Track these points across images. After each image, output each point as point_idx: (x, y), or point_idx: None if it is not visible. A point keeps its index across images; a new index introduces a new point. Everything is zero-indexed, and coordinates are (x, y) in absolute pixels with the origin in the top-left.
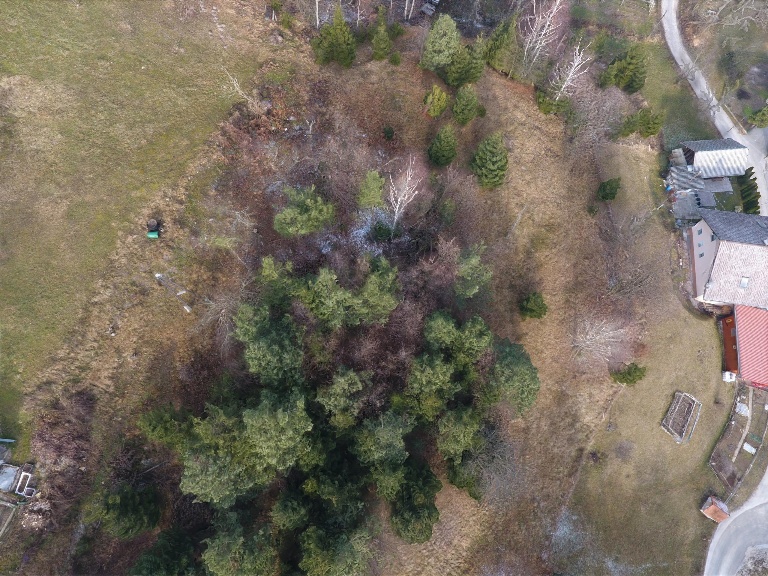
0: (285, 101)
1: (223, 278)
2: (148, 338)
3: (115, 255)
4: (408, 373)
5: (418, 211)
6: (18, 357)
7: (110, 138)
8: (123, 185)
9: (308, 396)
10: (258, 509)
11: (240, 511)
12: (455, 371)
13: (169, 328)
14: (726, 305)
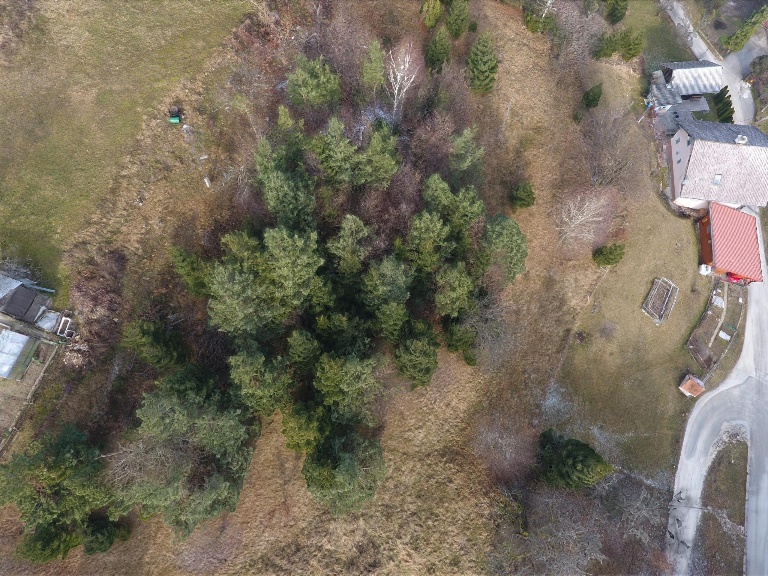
0: (292, 13)
1: (239, 158)
2: (172, 209)
3: (141, 136)
4: (408, 231)
5: (416, 115)
6: (56, 219)
7: (133, 37)
8: (146, 77)
9: (319, 247)
10: (275, 349)
11: (260, 346)
12: (451, 237)
13: (191, 200)
14: (703, 208)
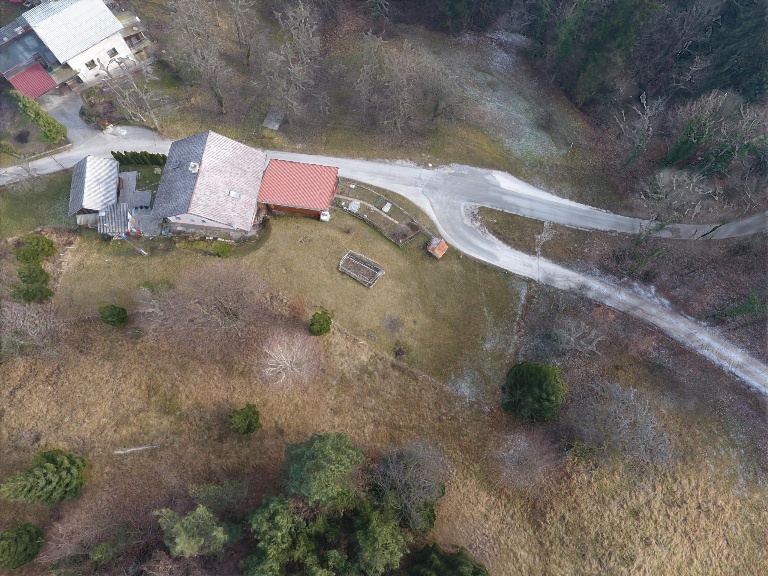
0: None
1: None
2: None
3: None
4: None
5: (106, 570)
6: None
7: None
8: None
9: None
10: None
11: None
12: (315, 547)
13: None
14: (257, 204)
